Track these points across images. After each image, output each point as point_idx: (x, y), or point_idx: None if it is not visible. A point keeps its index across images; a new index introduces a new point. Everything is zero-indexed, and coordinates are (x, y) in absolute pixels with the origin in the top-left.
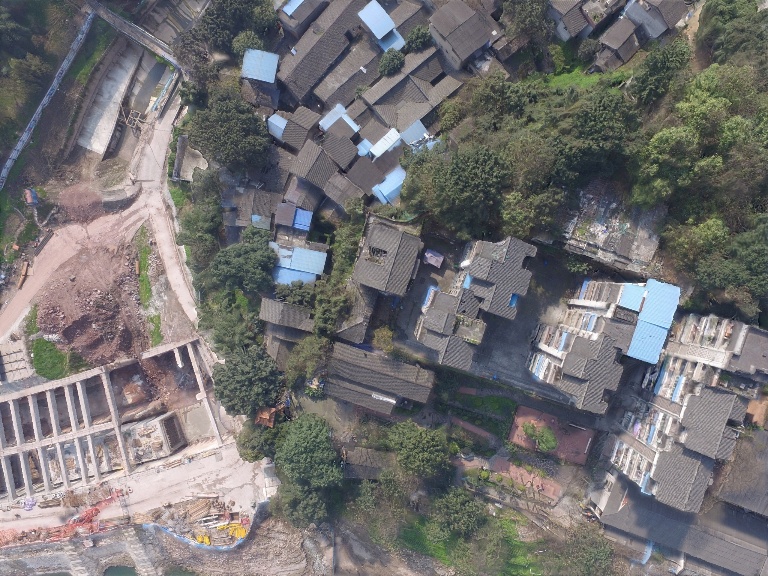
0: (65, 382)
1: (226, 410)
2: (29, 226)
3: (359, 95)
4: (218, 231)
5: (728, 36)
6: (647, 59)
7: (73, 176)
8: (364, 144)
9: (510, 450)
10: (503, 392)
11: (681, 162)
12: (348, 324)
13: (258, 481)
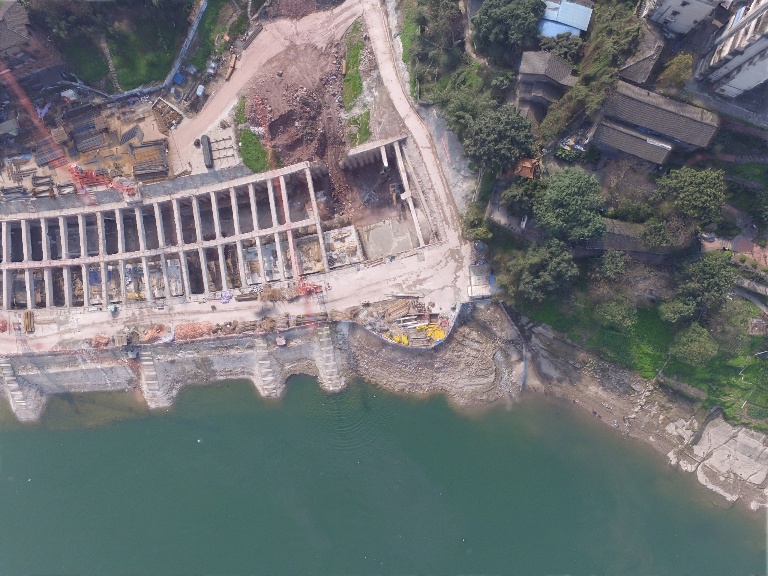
0: (269, 175)
1: (484, 161)
2: (241, 17)
3: None
4: None
5: None
6: None
7: None
8: None
9: None
10: (765, 158)
11: None
12: (634, 60)
13: (459, 283)
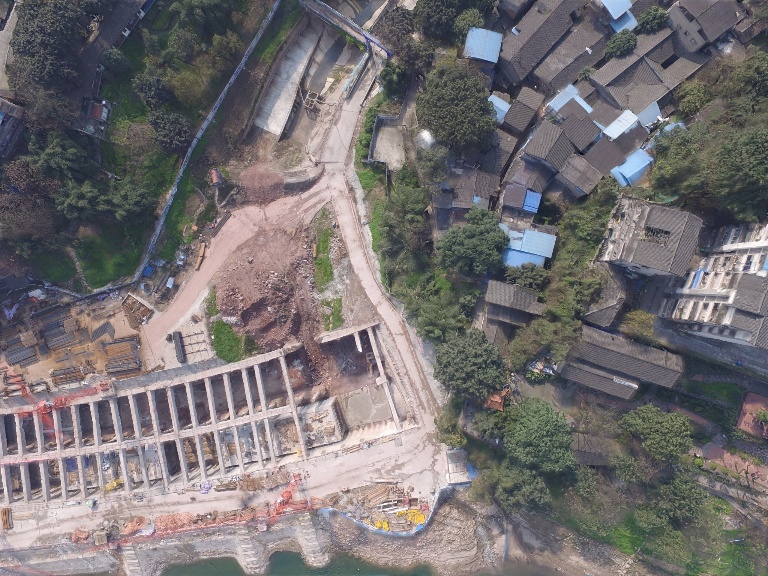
0: (243, 365)
1: (453, 393)
2: (208, 207)
3: (586, 76)
4: None
5: None
6: None
7: (251, 157)
8: None
9: (738, 437)
10: (731, 379)
11: None
12: (597, 307)
13: (438, 467)
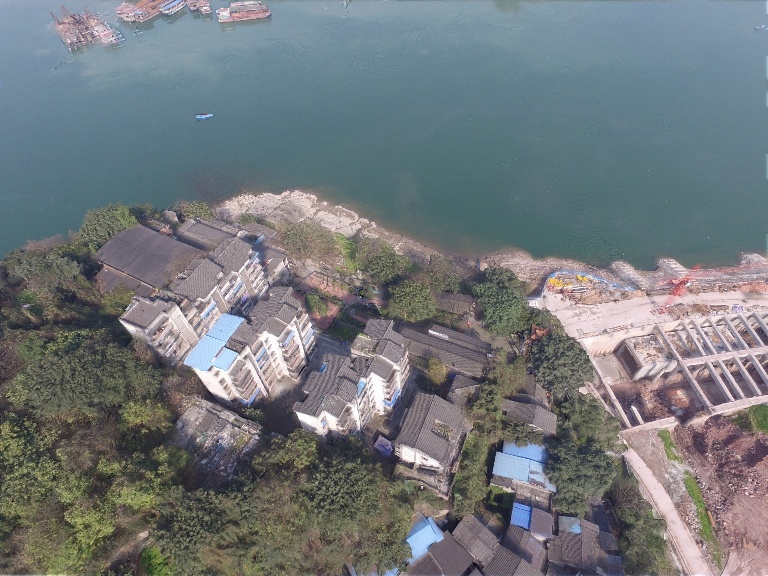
0: (746, 402)
1: None
2: None
3: None
4: (620, 531)
5: None
6: None
7: None
8: None
9: (340, 301)
10: None
11: (135, 470)
12: (469, 390)
13: None
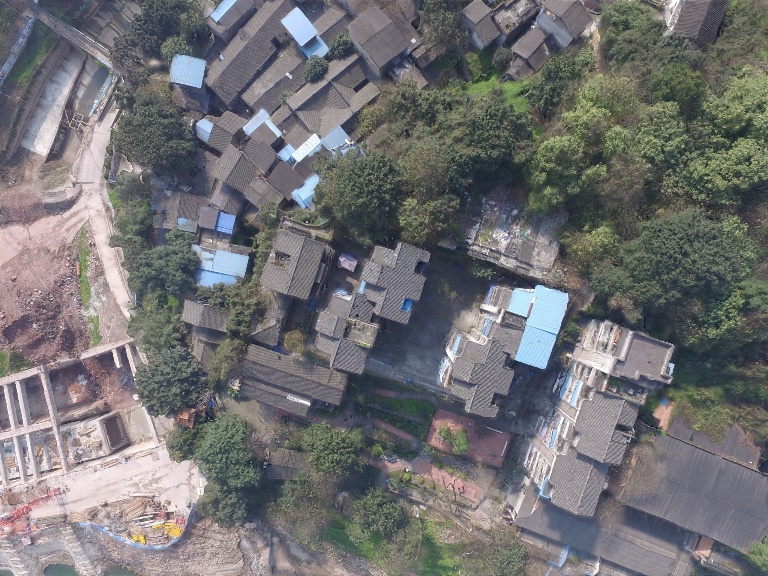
0: (4, 381)
1: None
2: None
3: (284, 101)
4: (150, 233)
5: (617, 47)
6: (543, 69)
7: (16, 177)
8: (287, 149)
9: (428, 452)
10: (421, 395)
11: (568, 171)
12: (262, 326)
13: (194, 481)
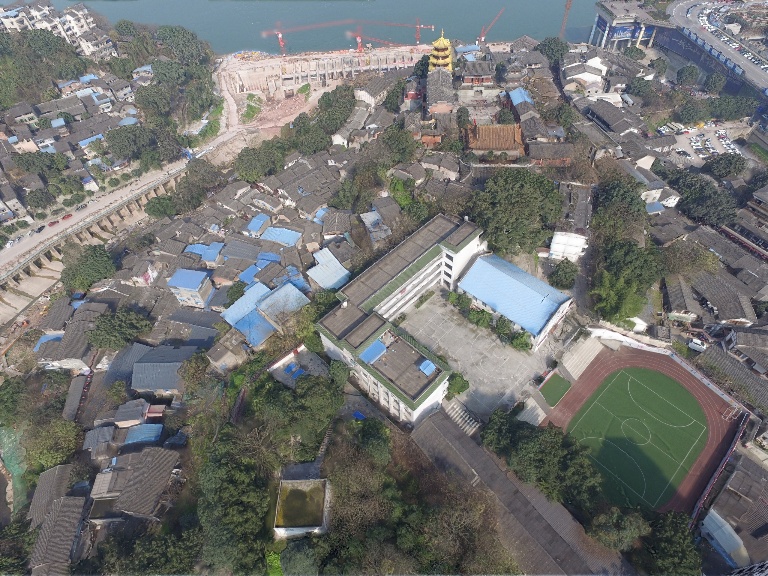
0: (299, 84)
1: None
2: None
3: None
4: None
5: None
6: None
7: None
8: None
9: None
10: None
11: None
12: None
13: (226, 65)
